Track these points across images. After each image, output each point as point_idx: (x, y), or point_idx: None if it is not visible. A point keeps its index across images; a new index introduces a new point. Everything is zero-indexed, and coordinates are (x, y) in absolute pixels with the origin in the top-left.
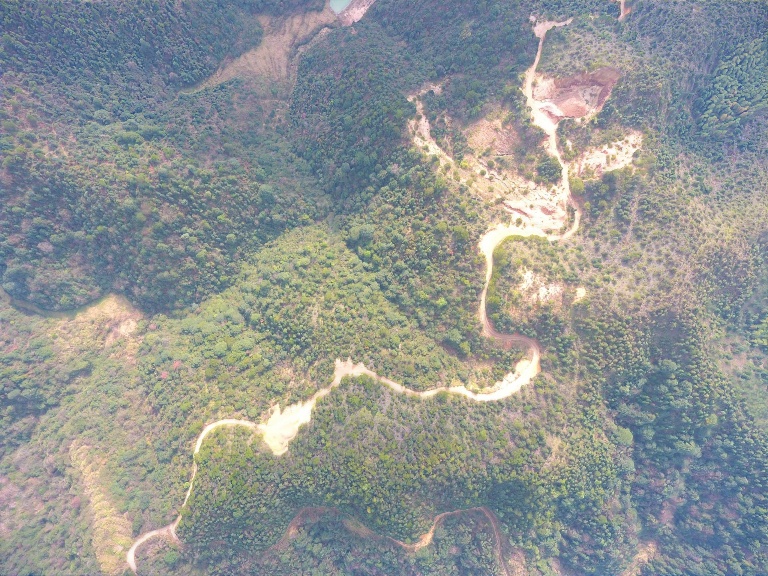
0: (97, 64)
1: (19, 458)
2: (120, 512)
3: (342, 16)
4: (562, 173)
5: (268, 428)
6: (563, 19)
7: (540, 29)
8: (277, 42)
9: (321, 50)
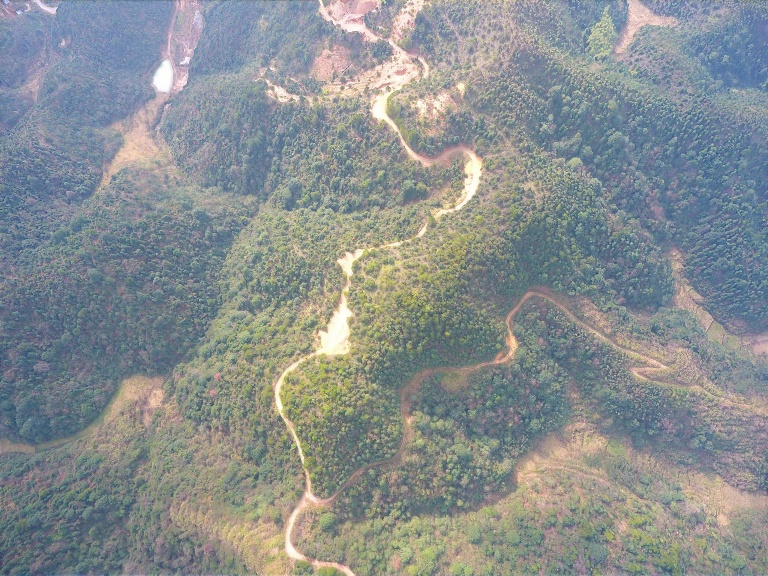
0: (2, 212)
1: (129, 572)
2: (253, 521)
3: (173, 91)
4: (391, 45)
5: (325, 349)
6: None
7: None
8: (136, 134)
9: (173, 114)
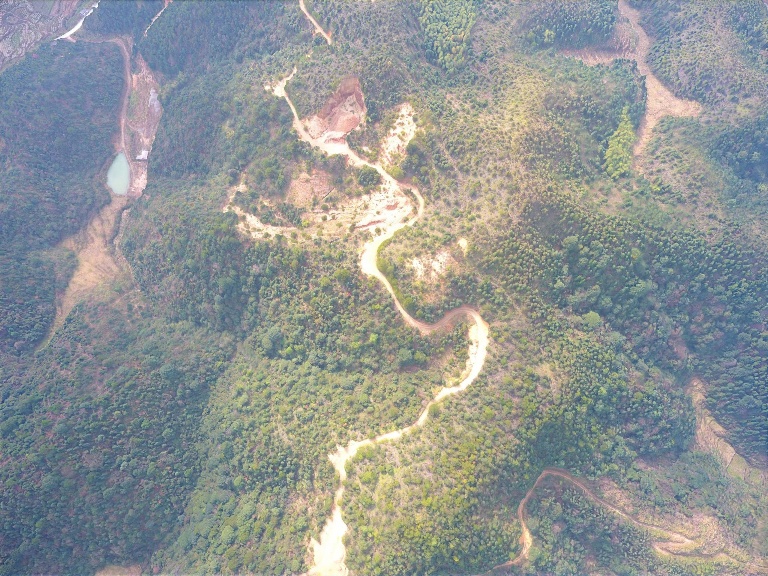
0: None
1: None
2: None
3: (131, 193)
4: (379, 172)
5: (319, 567)
6: (290, 72)
7: (279, 90)
8: (92, 251)
9: (132, 230)
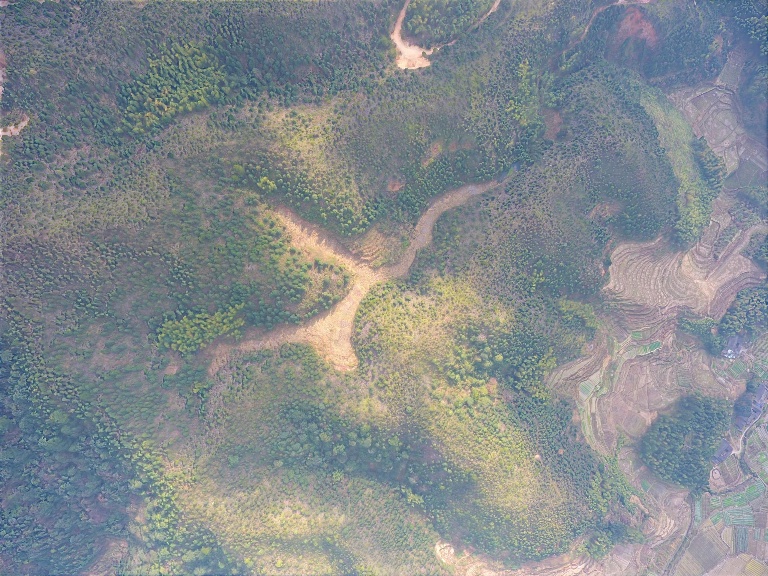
0: None
1: None
2: None
3: None
4: None
5: None
6: None
7: None
8: None
9: None
